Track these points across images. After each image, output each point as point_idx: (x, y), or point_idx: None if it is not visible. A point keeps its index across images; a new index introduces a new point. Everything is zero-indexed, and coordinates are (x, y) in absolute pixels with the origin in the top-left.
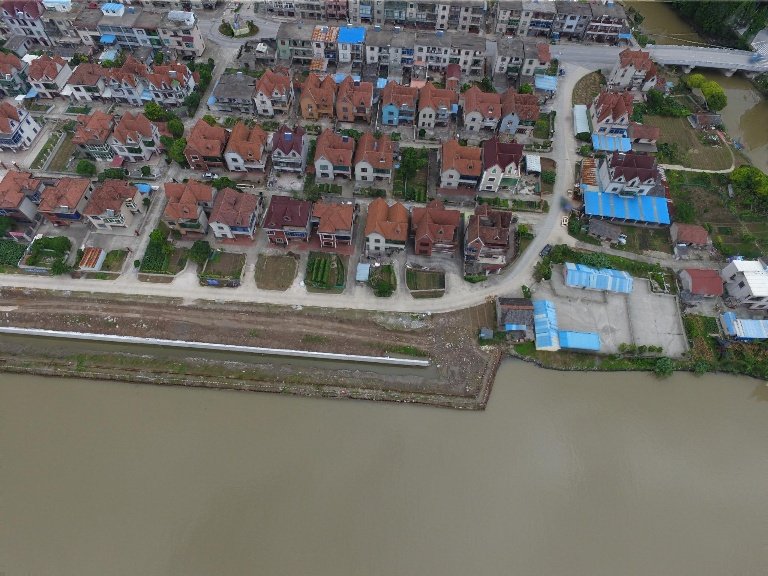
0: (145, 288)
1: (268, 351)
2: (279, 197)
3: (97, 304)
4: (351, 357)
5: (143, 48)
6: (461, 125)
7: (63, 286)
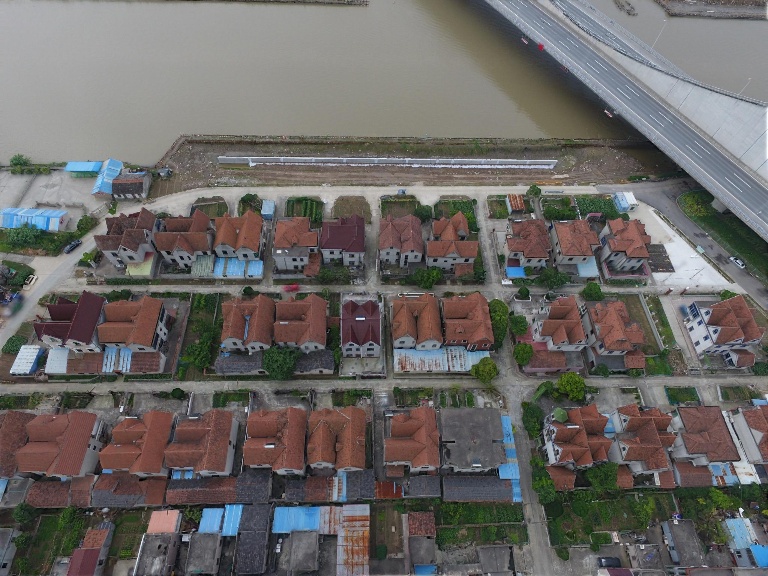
0: (459, 191)
1: (345, 160)
2: (354, 241)
3: (492, 181)
4: (279, 157)
5: (698, 561)
6: (110, 438)
7: (527, 188)
